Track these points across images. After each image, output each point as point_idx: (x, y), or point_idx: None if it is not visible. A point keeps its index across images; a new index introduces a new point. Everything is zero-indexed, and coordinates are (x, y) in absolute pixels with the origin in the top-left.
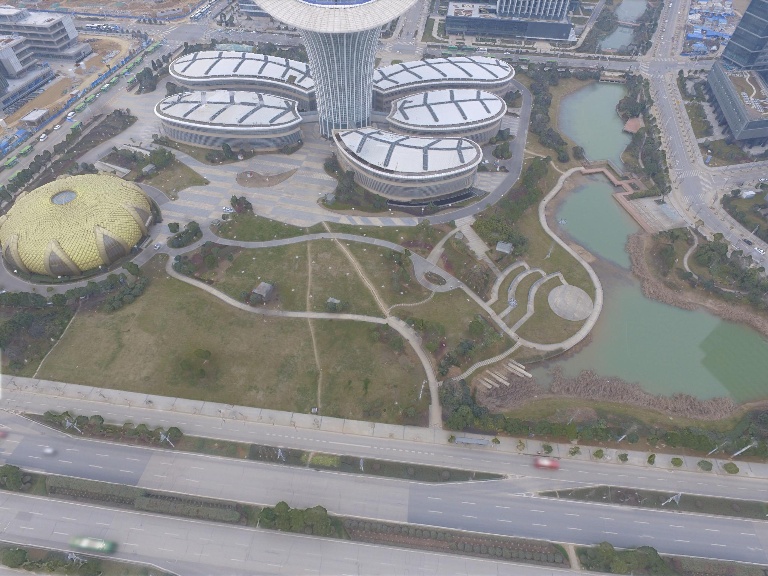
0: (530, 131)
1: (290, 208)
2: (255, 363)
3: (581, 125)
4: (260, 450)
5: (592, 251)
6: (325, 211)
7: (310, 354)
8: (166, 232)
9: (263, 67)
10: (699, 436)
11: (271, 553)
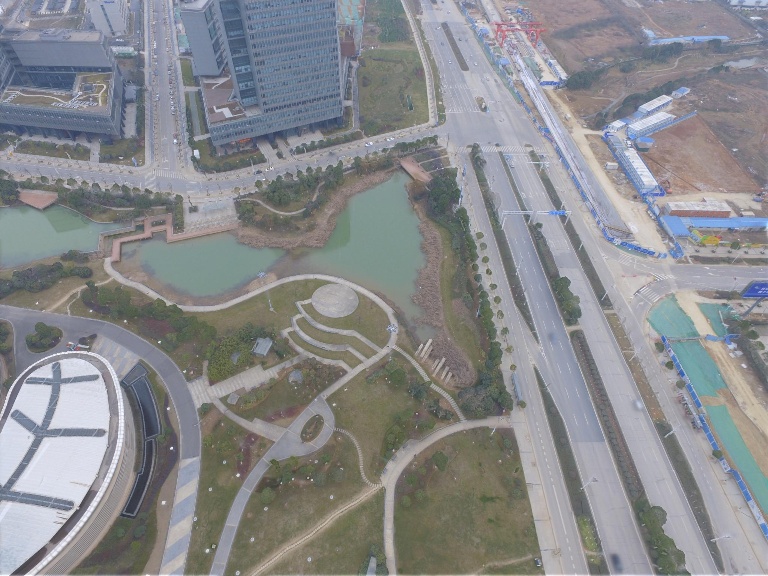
0: None
1: None
2: None
3: (6, 245)
4: None
5: None
6: None
7: None
8: None
9: None
10: (470, 241)
11: (695, 572)
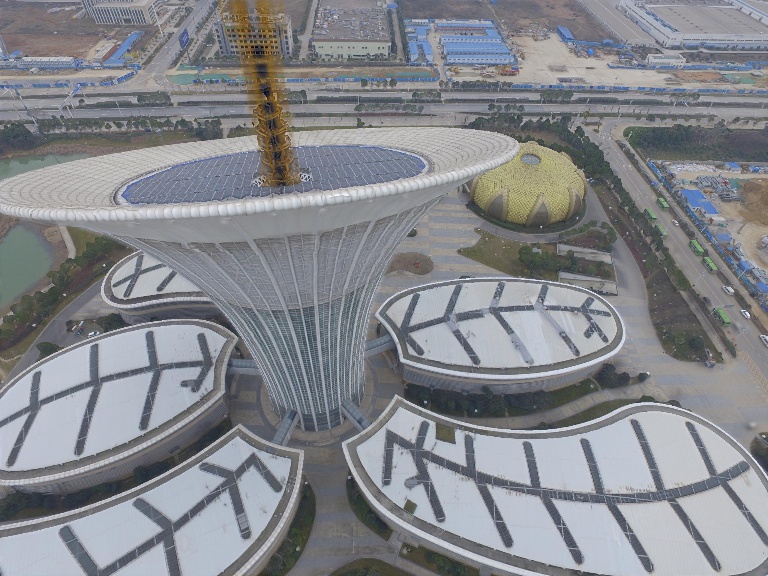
0: None
1: None
2: None
3: None
4: (316, 114)
5: (40, 238)
6: None
7: None
8: (454, 199)
9: (531, 461)
10: (83, 122)
11: None
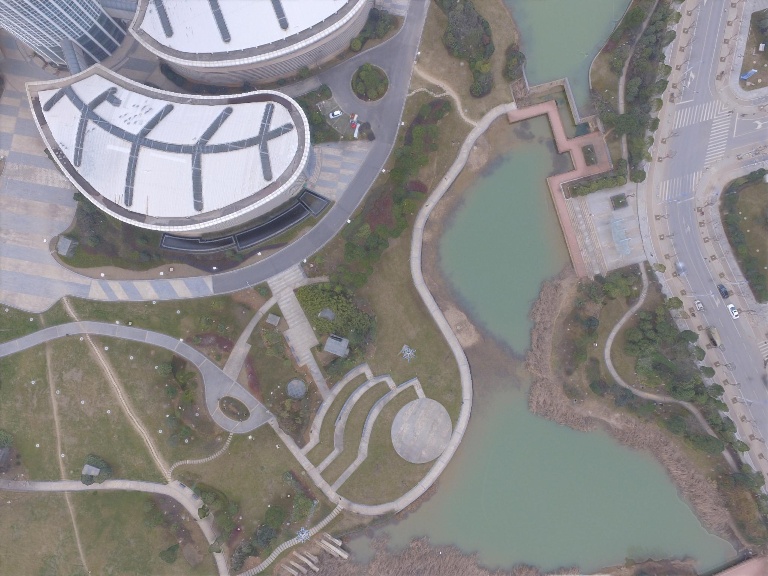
0: (434, 0)
1: (8, 268)
2: (8, 569)
3: None
4: None
5: (478, 321)
6: (64, 271)
7: (73, 551)
8: None
9: None
10: None
11: None
